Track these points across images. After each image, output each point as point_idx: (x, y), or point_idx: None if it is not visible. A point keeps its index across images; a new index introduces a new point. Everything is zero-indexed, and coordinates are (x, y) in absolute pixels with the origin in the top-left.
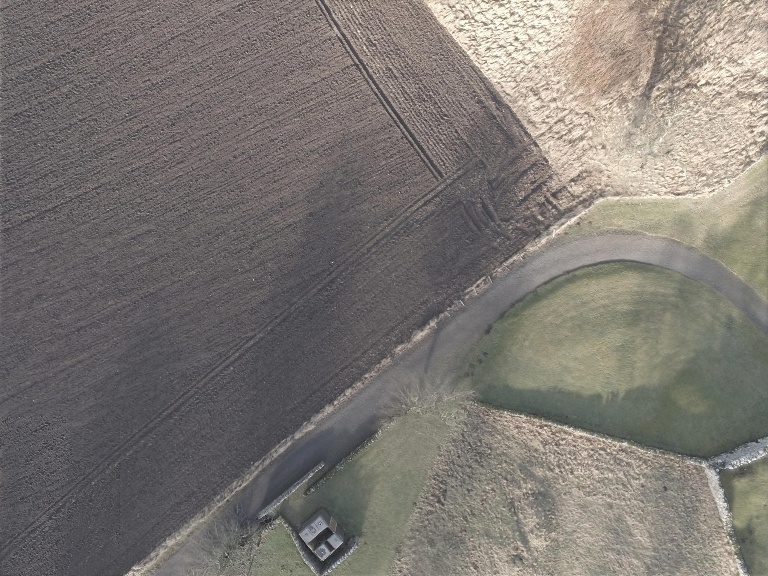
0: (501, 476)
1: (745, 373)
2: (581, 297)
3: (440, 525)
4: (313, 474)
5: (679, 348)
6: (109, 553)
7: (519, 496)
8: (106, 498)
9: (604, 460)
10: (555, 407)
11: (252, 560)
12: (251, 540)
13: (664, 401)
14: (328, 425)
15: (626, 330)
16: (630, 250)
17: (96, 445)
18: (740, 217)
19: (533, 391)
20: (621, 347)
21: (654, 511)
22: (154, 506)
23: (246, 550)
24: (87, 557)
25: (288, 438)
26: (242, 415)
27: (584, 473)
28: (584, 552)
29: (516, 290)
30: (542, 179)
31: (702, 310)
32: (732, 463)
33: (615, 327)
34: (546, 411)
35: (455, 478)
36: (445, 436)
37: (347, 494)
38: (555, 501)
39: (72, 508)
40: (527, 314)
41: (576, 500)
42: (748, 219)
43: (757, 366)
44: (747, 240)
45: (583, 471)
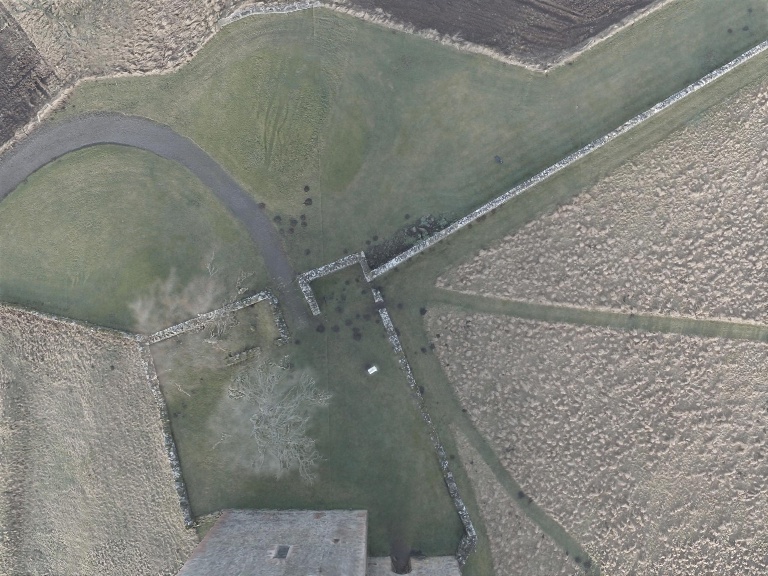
0: None
1: (207, 250)
2: (62, 182)
3: None
4: None
5: (141, 227)
6: None
7: None
8: None
9: (65, 344)
10: (33, 295)
11: None
12: None
13: (120, 280)
14: None
15: (95, 212)
16: (109, 132)
17: None
18: (204, 91)
19: (16, 280)
20: (89, 229)
21: (100, 391)
22: None
23: None
24: None
25: None
26: None
27: (51, 359)
28: (52, 439)
29: (9, 180)
30: (31, 65)
31: (170, 188)
32: (155, 334)
33: (86, 209)
34: (26, 299)
35: None
36: None
37: None
38: (26, 389)
39: None
40: (14, 203)
41: (46, 387)
42: (210, 92)
43: (219, 242)
44: (209, 114)
45: (50, 357)
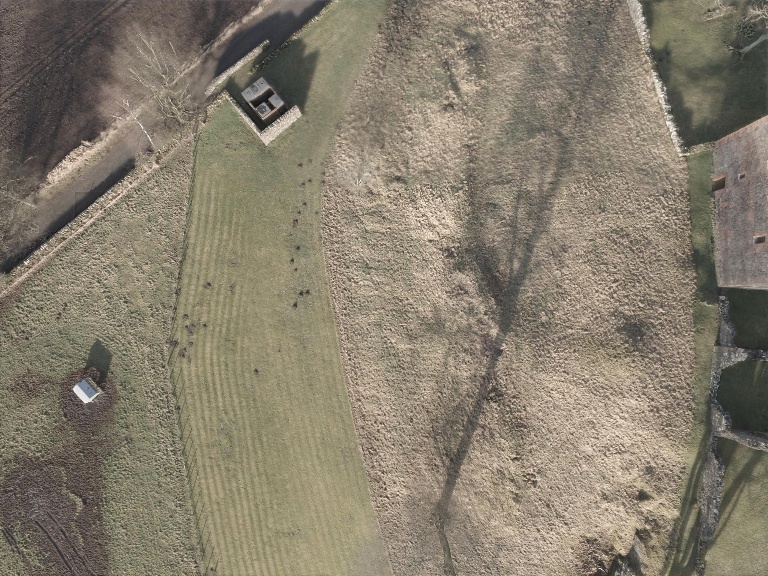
0: (437, 43)
1: None
2: None
3: (379, 99)
4: (258, 51)
5: None
6: (61, 134)
7: (453, 55)
8: (60, 82)
9: (533, 7)
10: None
11: (198, 138)
12: (197, 115)
13: None
14: (275, 10)
15: None
16: None
17: (51, 32)
18: None
19: None
20: None
21: (578, 43)
22: (105, 89)
23: (192, 127)
24: (40, 138)
25: (236, 22)
26: (192, 2)
27: (514, 24)
28: (512, 98)
29: None
30: None
31: None
32: None
33: None
34: None
35: (394, 52)
36: (386, 15)
37: (291, 74)
38: (486, 53)
39: (27, 91)
40: None
41: (506, 51)
42: None
43: None
44: None
45: (514, 22)
